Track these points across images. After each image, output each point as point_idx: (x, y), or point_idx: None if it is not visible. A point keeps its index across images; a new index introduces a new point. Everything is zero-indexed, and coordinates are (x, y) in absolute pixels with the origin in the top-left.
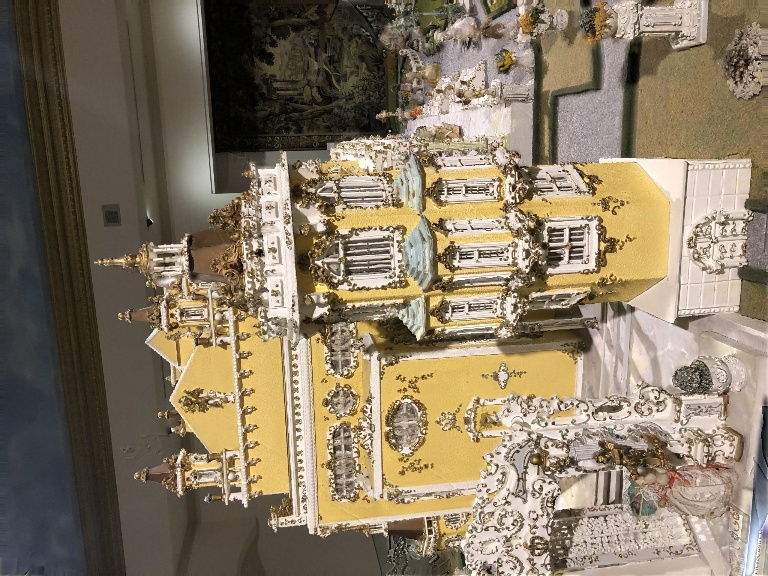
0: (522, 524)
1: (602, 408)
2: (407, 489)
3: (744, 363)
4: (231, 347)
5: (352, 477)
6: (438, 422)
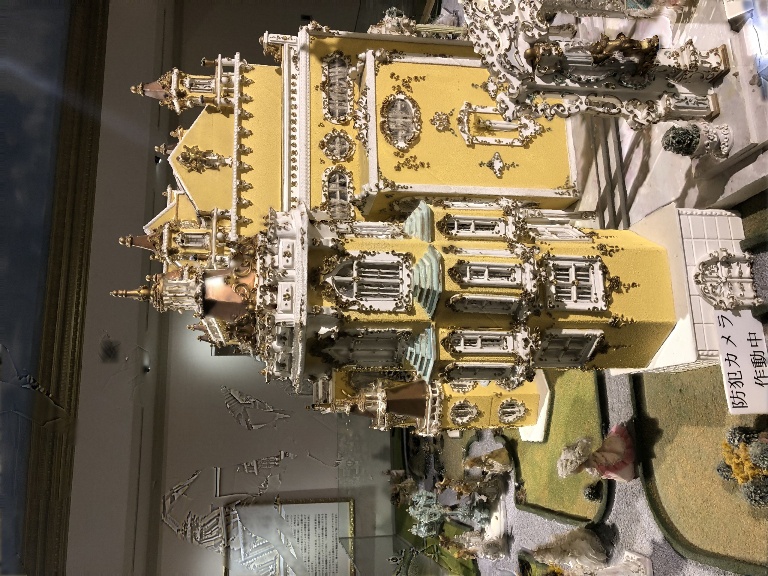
0: None
1: None
2: (403, 184)
3: None
4: None
5: None
6: (432, 120)
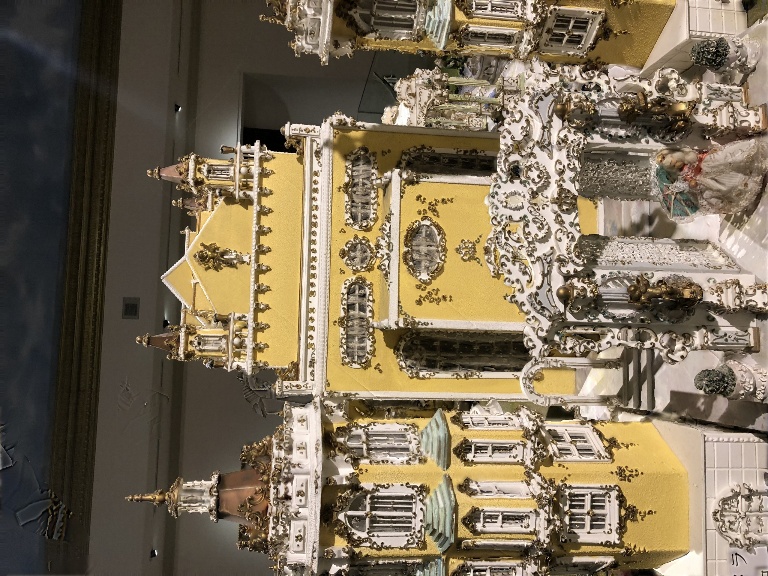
0: (548, 182)
1: (626, 234)
2: (424, 321)
3: (757, 36)
4: (253, 202)
5: (364, 343)
6: (457, 249)
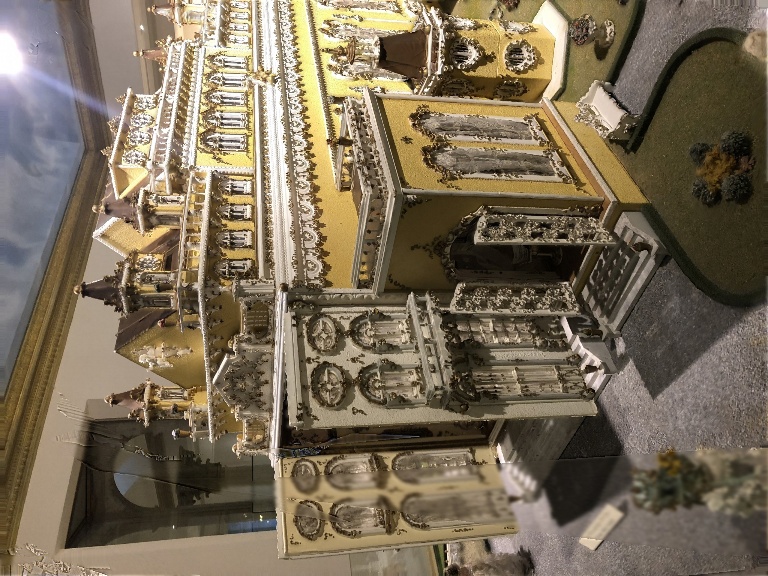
0: None
1: None
2: None
3: None
4: None
5: None
6: None
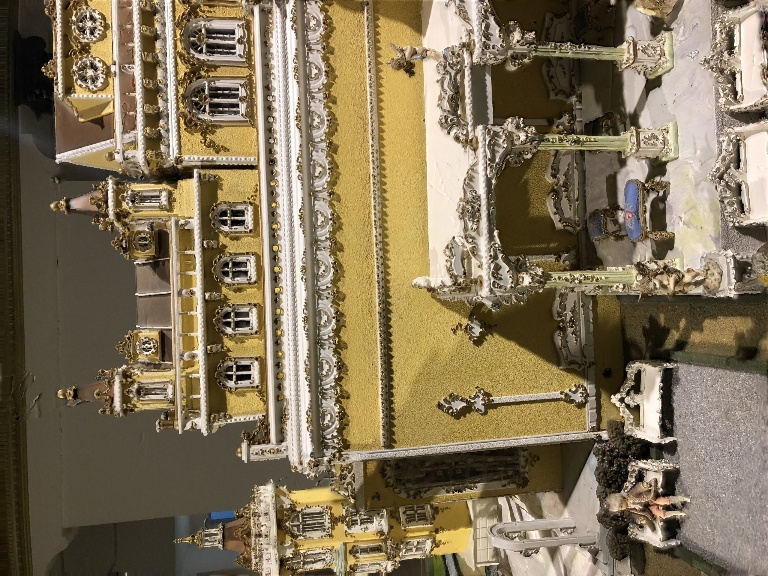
0: None
1: None
2: None
3: None
4: None
5: None
6: None
